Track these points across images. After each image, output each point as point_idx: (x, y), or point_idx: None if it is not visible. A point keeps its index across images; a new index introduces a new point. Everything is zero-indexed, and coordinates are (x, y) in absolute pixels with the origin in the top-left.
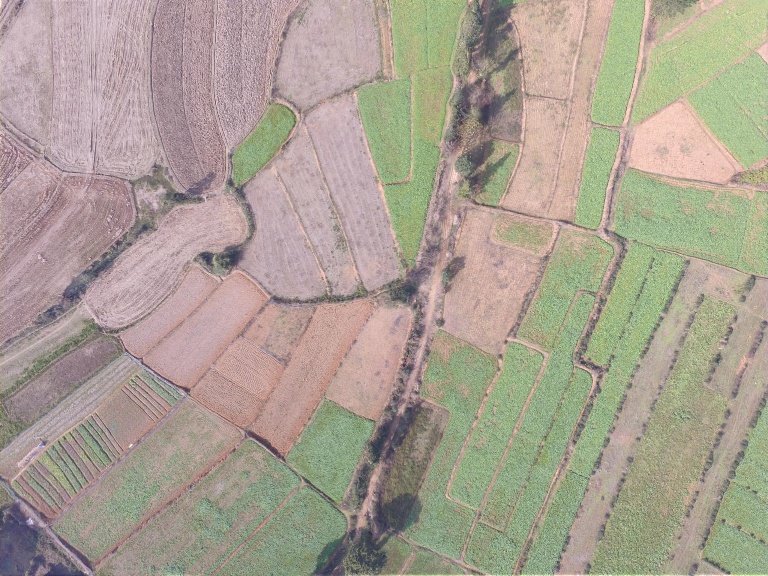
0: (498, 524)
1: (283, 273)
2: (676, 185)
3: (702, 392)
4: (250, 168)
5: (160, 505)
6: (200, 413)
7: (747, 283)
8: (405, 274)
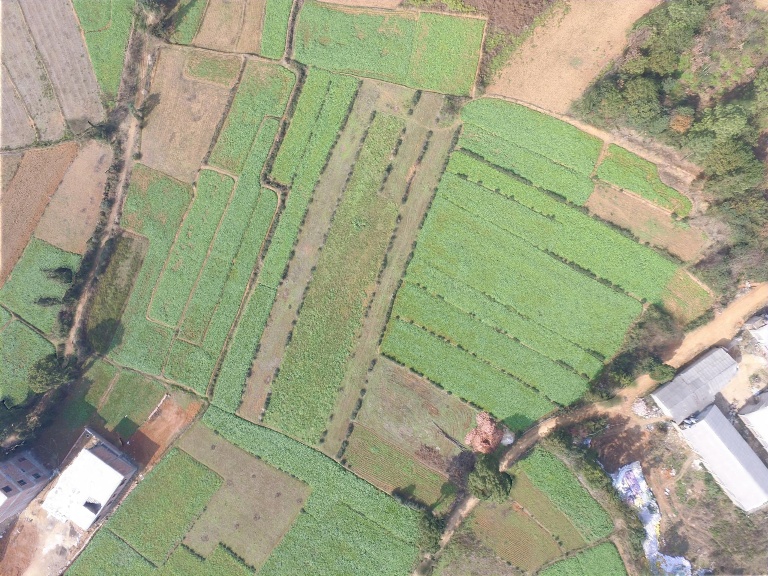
0: (194, 339)
1: None
2: (351, 12)
3: (376, 201)
4: None
5: None
6: None
7: (413, 96)
8: (106, 114)
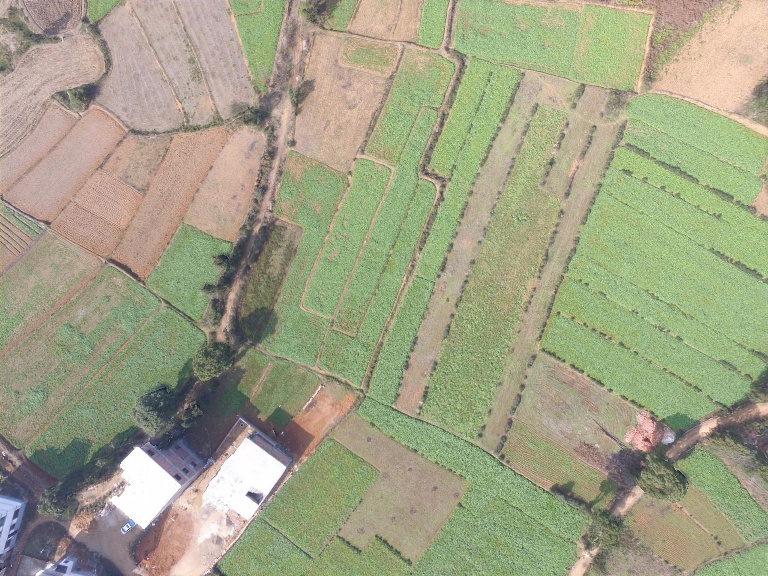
0: (350, 330)
1: (140, 107)
2: (512, 3)
3: (537, 195)
4: (105, 5)
5: (23, 335)
6: (61, 244)
7: (577, 90)
8: (258, 100)
